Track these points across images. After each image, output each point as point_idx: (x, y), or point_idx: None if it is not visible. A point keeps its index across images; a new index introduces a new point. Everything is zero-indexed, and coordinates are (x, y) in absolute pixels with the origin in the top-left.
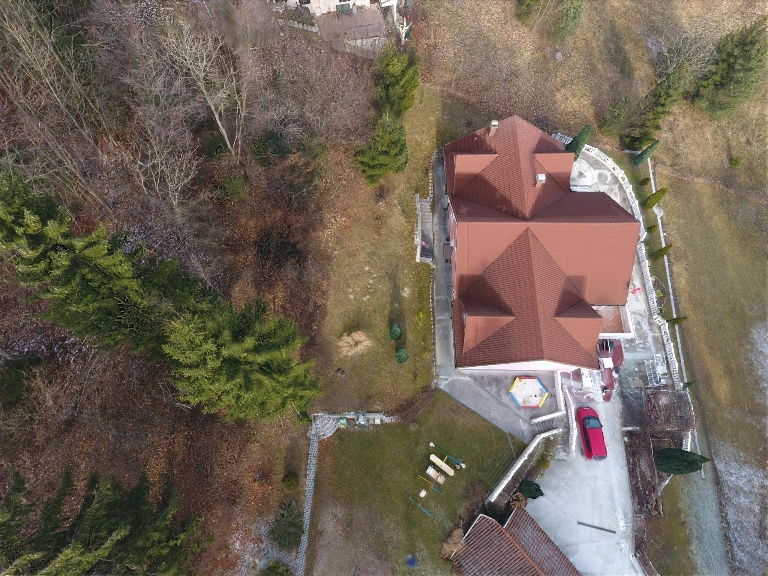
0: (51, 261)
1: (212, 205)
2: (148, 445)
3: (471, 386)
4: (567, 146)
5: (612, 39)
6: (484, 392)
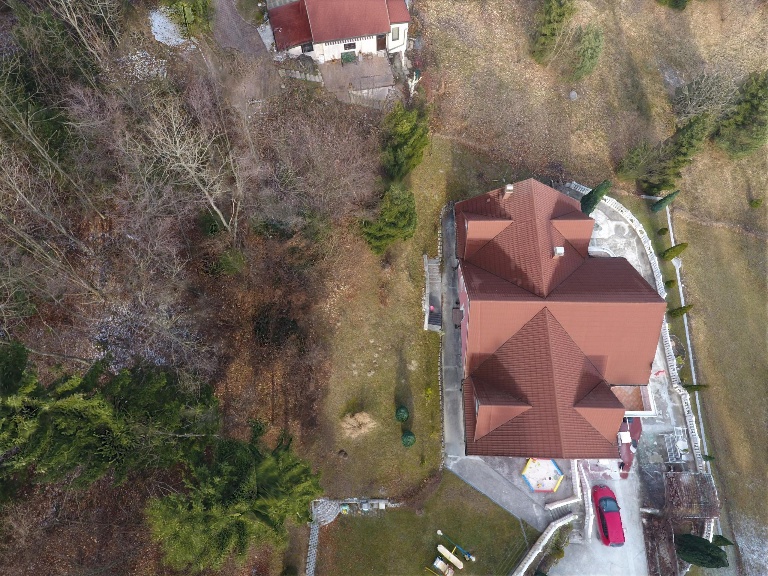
0: (16, 426)
1: (207, 279)
2: (136, 546)
3: (481, 467)
4: (583, 199)
5: (628, 73)
6: (495, 473)
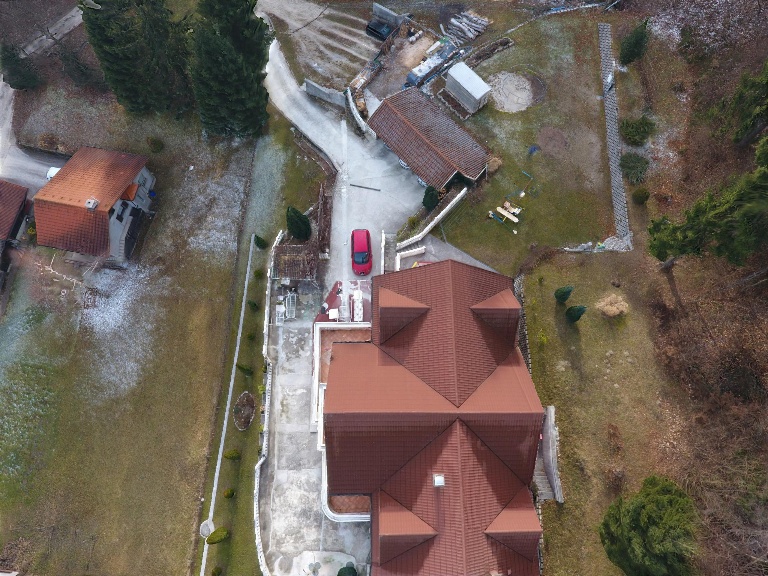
0: None
1: None
2: None
3: None
4: None
5: None
6: None
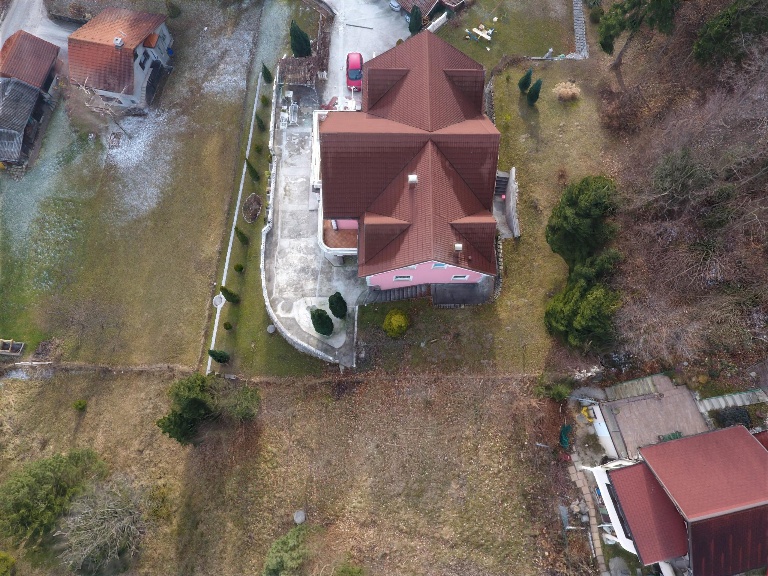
0: None
1: None
2: (718, 7)
3: None
4: None
5: None
6: None
